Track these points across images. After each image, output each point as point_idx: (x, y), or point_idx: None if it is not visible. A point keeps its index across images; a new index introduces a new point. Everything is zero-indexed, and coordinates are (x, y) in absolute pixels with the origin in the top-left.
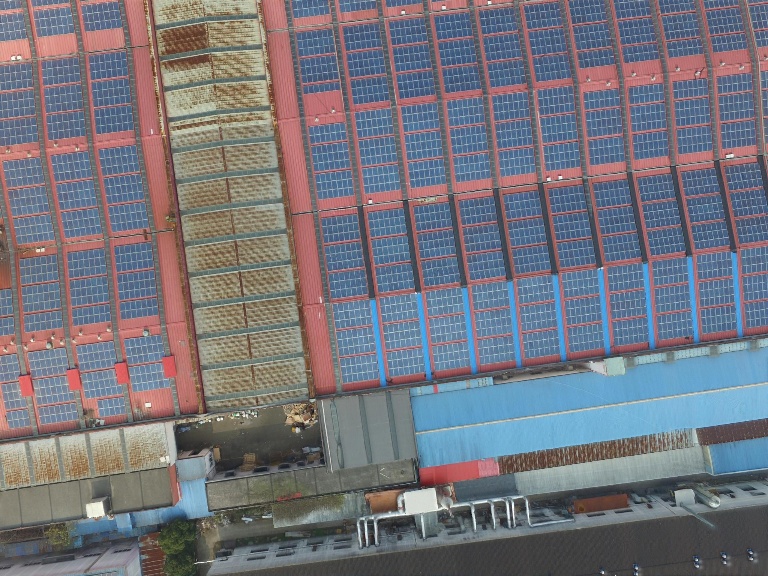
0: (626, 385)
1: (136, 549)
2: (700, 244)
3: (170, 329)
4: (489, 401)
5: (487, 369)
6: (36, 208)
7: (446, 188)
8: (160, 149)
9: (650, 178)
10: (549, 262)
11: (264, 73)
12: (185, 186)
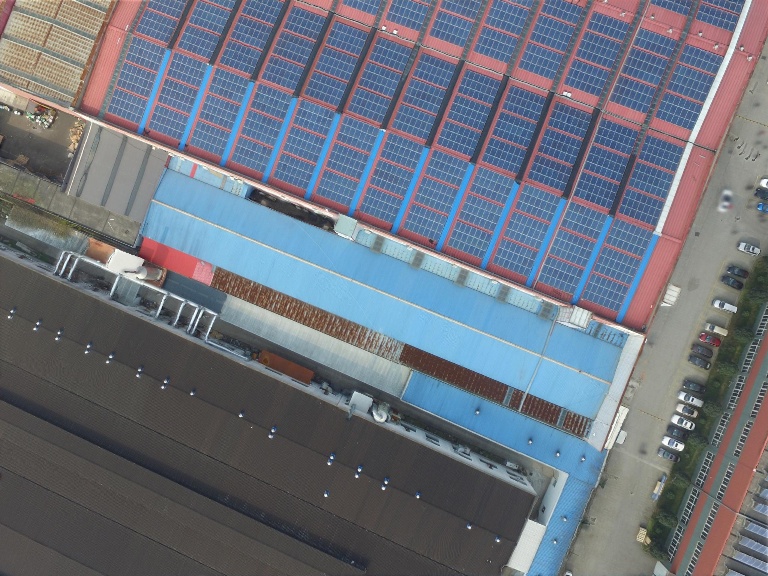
0: (361, 264)
1: None
2: (489, 158)
3: None
4: (232, 209)
5: (235, 168)
6: None
7: None
8: None
9: (478, 75)
10: (340, 100)
11: None
12: None
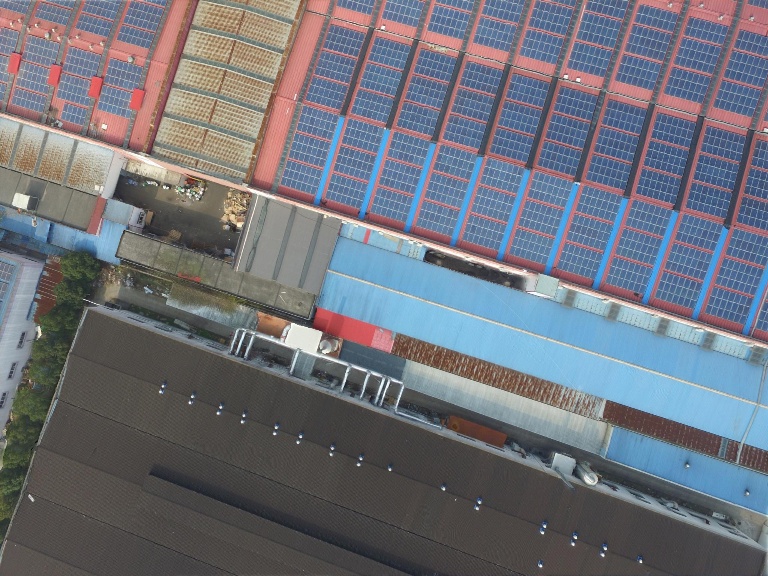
0: (554, 321)
1: (42, 263)
2: (693, 204)
3: (153, 66)
4: (411, 274)
5: (420, 233)
6: None
7: (461, 44)
8: None
9: (671, 118)
10: (528, 155)
11: None
12: None
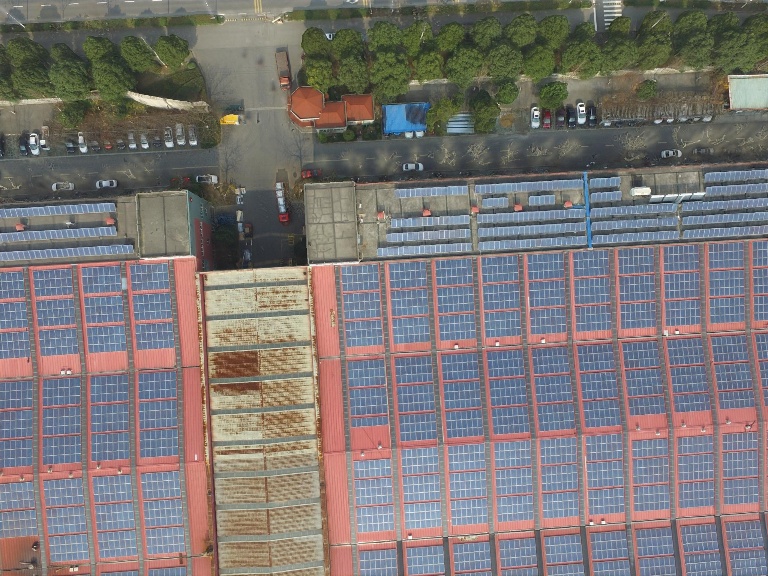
0: None
1: None
2: None
3: None
4: None
5: None
6: (73, 527)
7: (487, 527)
8: (203, 475)
9: (694, 527)
10: None
11: (313, 401)
12: (225, 512)
